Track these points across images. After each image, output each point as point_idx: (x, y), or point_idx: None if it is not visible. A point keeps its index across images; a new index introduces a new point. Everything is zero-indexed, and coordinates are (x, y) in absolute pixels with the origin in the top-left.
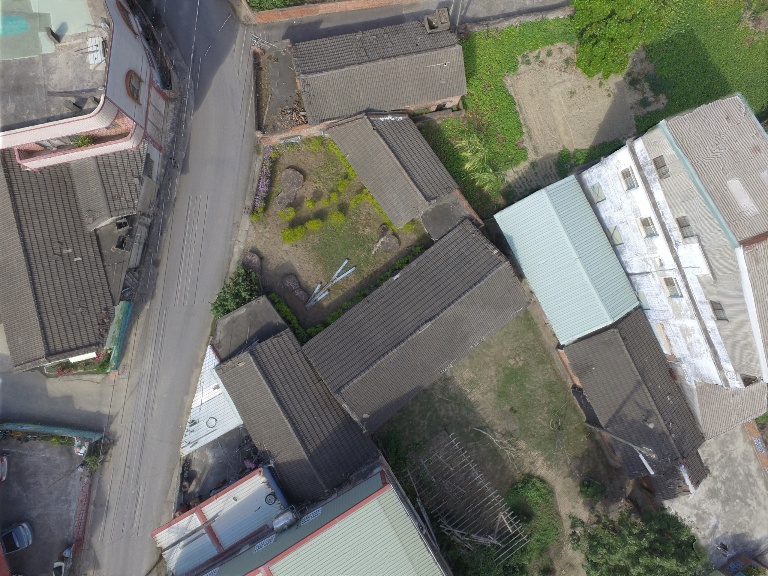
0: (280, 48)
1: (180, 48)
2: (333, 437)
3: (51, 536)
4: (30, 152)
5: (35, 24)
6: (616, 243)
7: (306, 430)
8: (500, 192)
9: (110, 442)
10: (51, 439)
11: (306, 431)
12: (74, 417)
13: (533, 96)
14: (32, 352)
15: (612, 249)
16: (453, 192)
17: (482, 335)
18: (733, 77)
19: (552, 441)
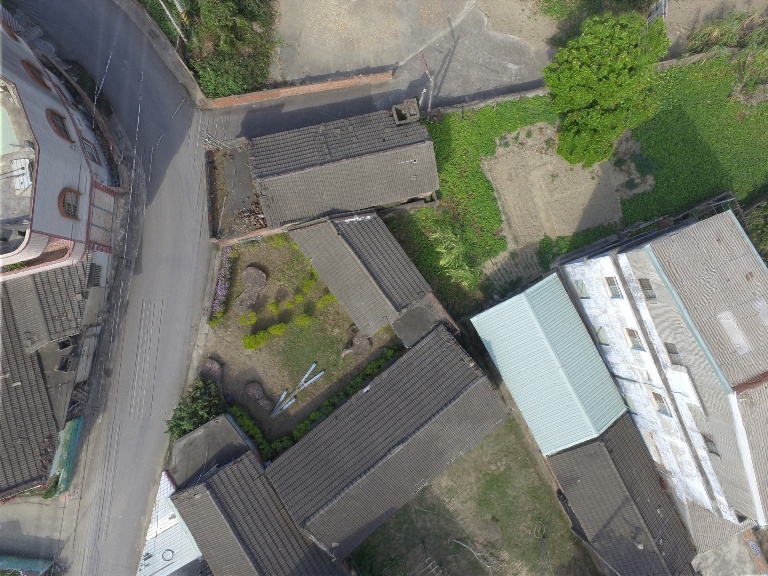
0: (235, 144)
1: (130, 137)
2: (300, 569)
3: None
4: None
5: None
6: (602, 342)
7: (270, 565)
8: (478, 286)
9: (61, 569)
10: None
11: (270, 566)
12: (21, 544)
13: (512, 181)
14: None
15: (597, 352)
16: (426, 295)
17: (459, 450)
18: (724, 156)
19: (537, 550)
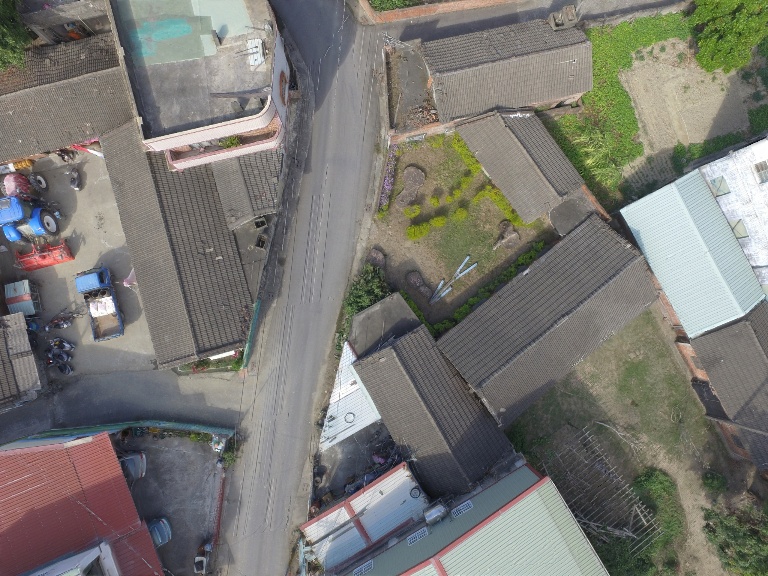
0: (409, 47)
1: (300, 49)
2: (471, 431)
3: (187, 531)
4: (179, 153)
5: (197, 27)
6: (738, 236)
7: (447, 424)
8: (618, 187)
9: (242, 438)
10: (187, 436)
11: (447, 425)
12: (206, 414)
13: (647, 91)
14: (180, 350)
15: (737, 242)
16: (580, 187)
17: (612, 329)
18: None
19: (673, 434)
